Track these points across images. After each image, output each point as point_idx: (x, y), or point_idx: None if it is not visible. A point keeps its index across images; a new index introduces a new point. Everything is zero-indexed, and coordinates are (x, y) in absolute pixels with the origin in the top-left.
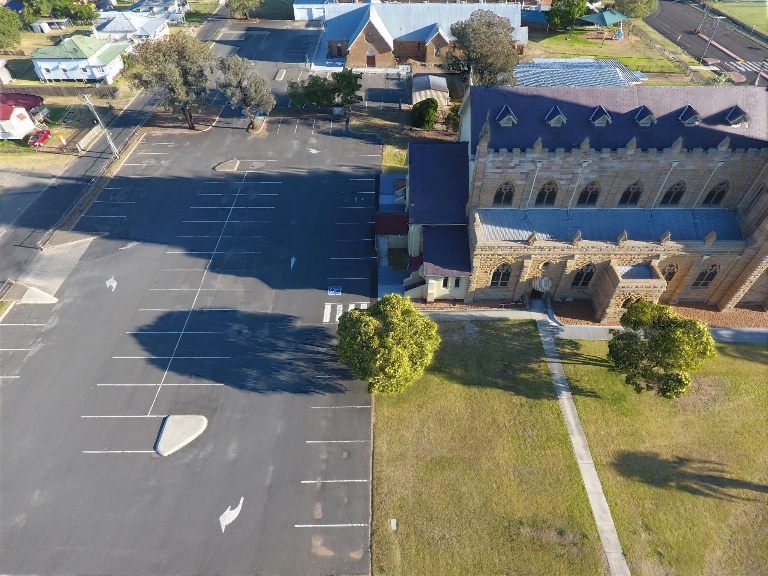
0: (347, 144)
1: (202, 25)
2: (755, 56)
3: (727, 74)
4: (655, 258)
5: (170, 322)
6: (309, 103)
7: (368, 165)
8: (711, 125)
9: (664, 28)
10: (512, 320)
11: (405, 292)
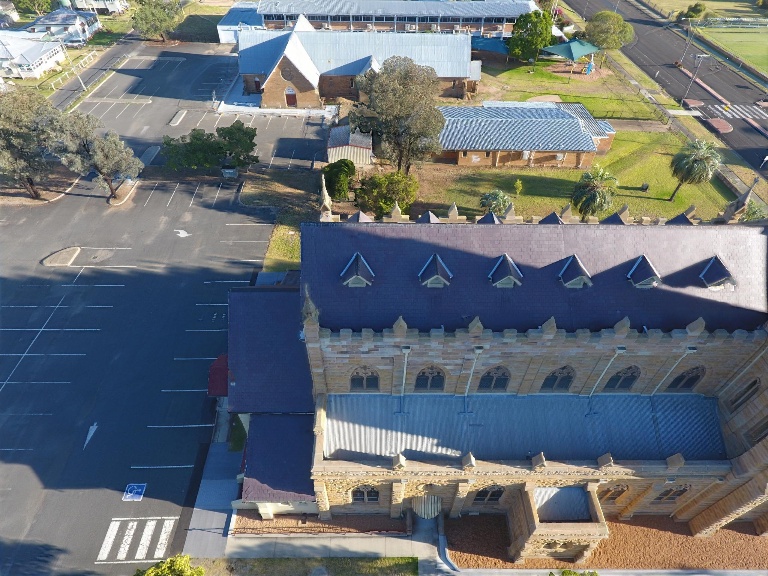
0: (229, 223)
1: (109, 48)
2: (743, 97)
3: (711, 122)
4: (593, 481)
5: None
6: (188, 166)
7: (247, 257)
8: (677, 286)
9: (642, 59)
10: (382, 559)
11: (231, 502)
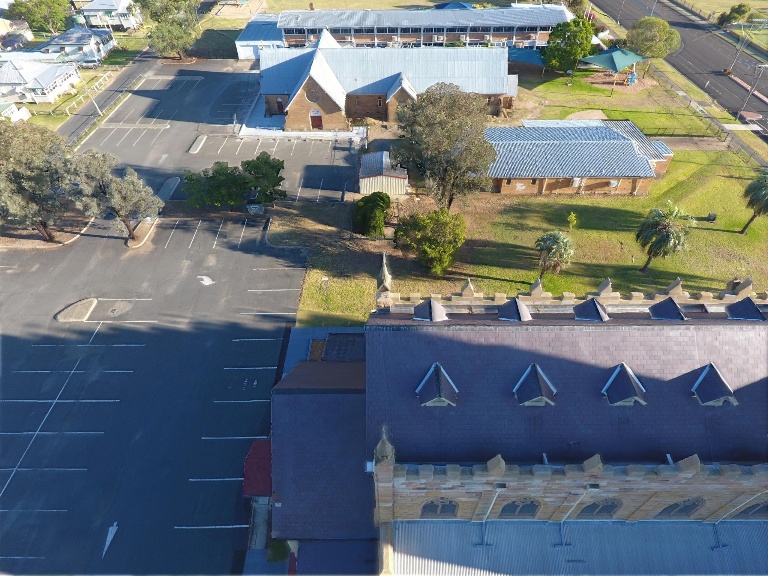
0: (257, 267)
1: (124, 68)
2: None
3: None
4: None
5: None
6: (211, 203)
7: (278, 309)
8: None
9: (686, 66)
10: None
11: None
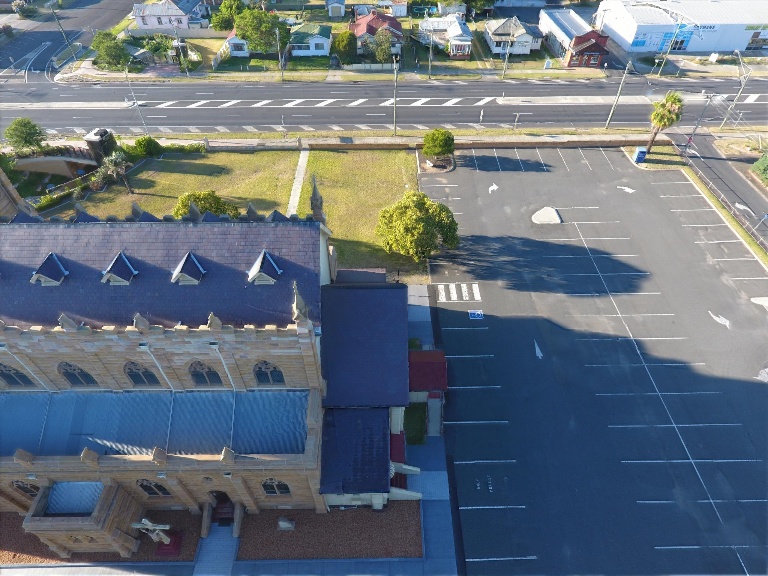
0: None
1: None
2: None
3: None
4: None
5: (619, 282)
6: None
7: None
8: None
9: None
10: None
11: None
